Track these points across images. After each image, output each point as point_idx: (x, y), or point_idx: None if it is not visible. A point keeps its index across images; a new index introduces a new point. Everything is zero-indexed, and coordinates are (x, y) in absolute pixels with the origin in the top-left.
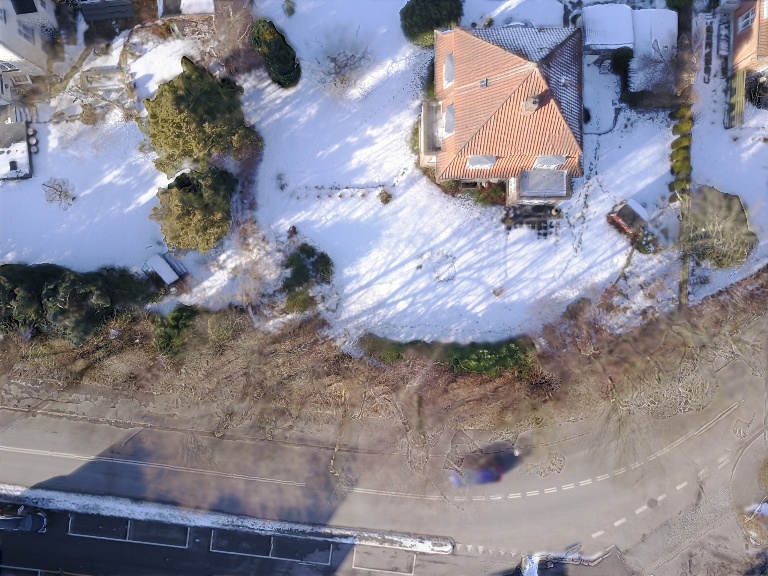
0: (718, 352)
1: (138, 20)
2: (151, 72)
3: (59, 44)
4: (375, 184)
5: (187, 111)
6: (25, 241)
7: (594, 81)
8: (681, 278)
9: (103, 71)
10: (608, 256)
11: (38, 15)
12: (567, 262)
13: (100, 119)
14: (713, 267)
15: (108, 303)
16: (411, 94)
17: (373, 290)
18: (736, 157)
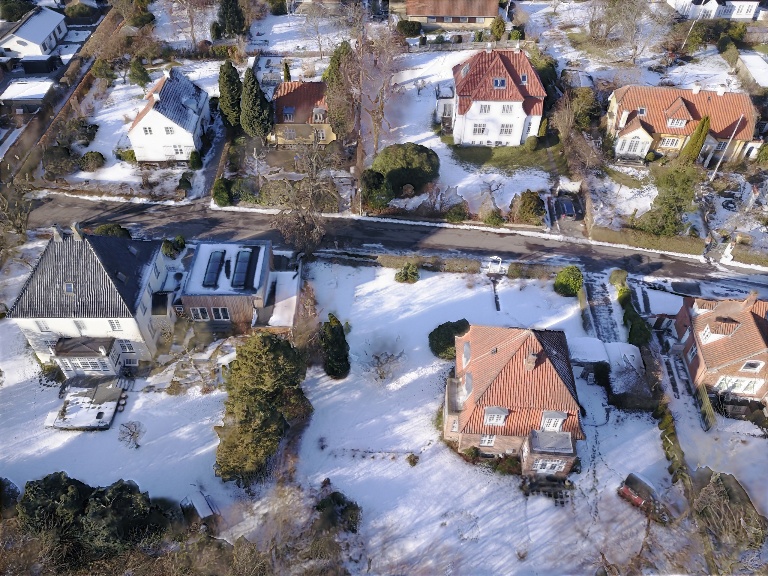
0: (748, 564)
1: (233, 334)
2: None
3: (169, 344)
4: (404, 451)
5: (270, 345)
6: None
7: (584, 389)
8: (704, 551)
9: (196, 362)
10: (626, 526)
11: (165, 318)
12: (587, 529)
13: (182, 392)
14: (733, 542)
15: (149, 507)
16: (436, 389)
17: (398, 543)
18: (722, 453)
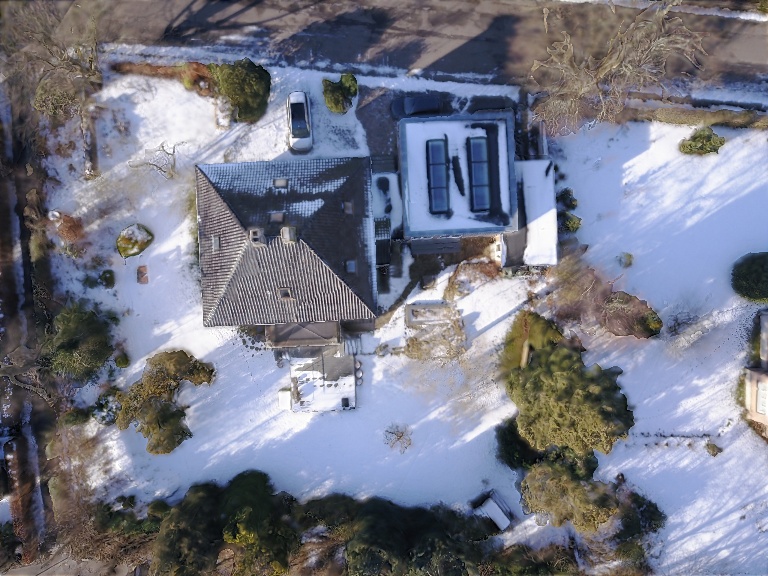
0: None
1: (464, 256)
2: (478, 310)
3: (385, 276)
4: (699, 432)
5: None
6: (344, 470)
7: None
8: None
9: (428, 305)
10: None
11: None
12: None
13: (425, 354)
14: None
15: None
16: (736, 344)
17: (695, 538)
18: None
